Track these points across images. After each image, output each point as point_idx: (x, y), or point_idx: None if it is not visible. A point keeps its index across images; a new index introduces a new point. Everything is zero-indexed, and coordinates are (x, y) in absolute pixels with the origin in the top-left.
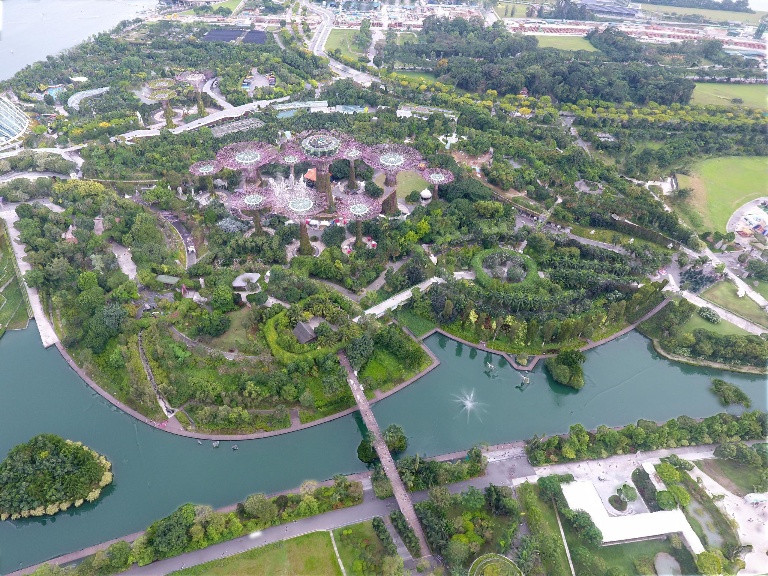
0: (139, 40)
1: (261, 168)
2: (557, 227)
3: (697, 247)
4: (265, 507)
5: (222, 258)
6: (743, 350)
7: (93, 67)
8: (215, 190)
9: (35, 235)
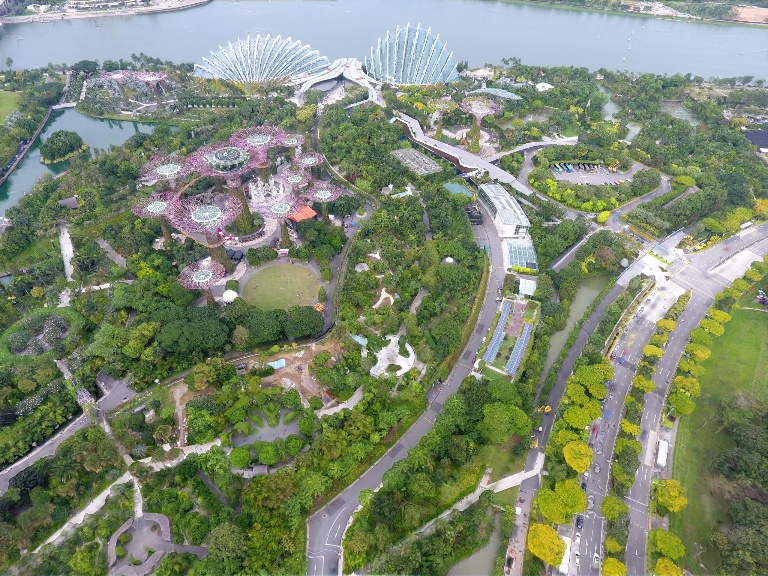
0: (700, 96)
1: None
2: None
3: None
4: None
5: None
6: None
7: None
8: None
9: None
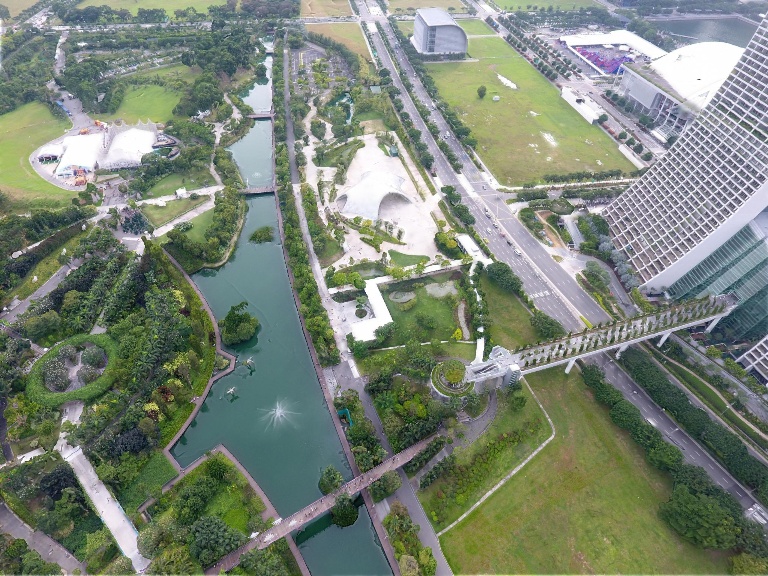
0: None
1: None
2: (4, 311)
3: (93, 211)
4: None
5: None
6: (229, 217)
7: None
8: None
9: None
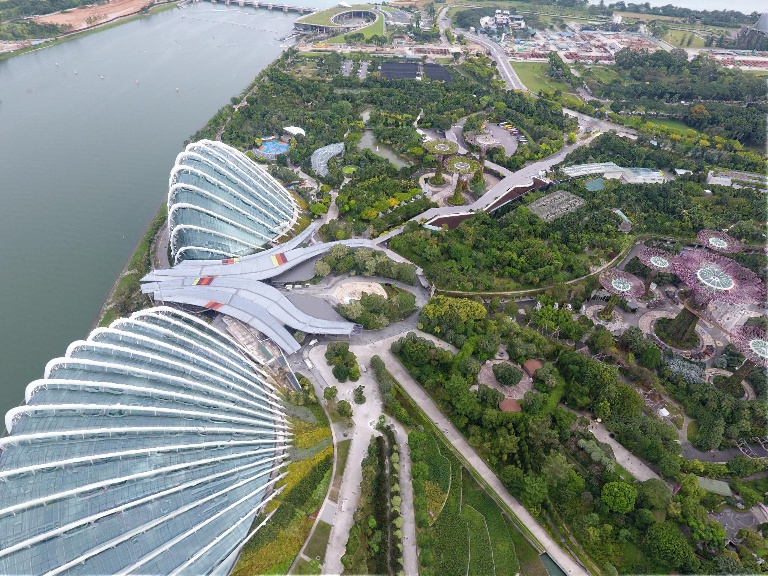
0: (316, 76)
1: (635, 269)
2: None
3: None
4: None
5: (737, 436)
6: None
7: (301, 114)
8: (594, 302)
9: (476, 402)
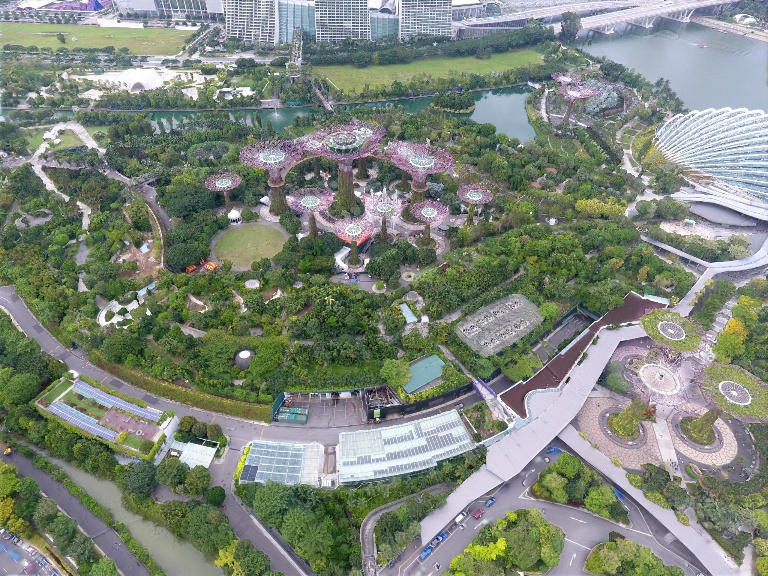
0: None
1: None
2: None
3: None
4: (366, 84)
5: None
6: None
7: None
8: None
9: None
